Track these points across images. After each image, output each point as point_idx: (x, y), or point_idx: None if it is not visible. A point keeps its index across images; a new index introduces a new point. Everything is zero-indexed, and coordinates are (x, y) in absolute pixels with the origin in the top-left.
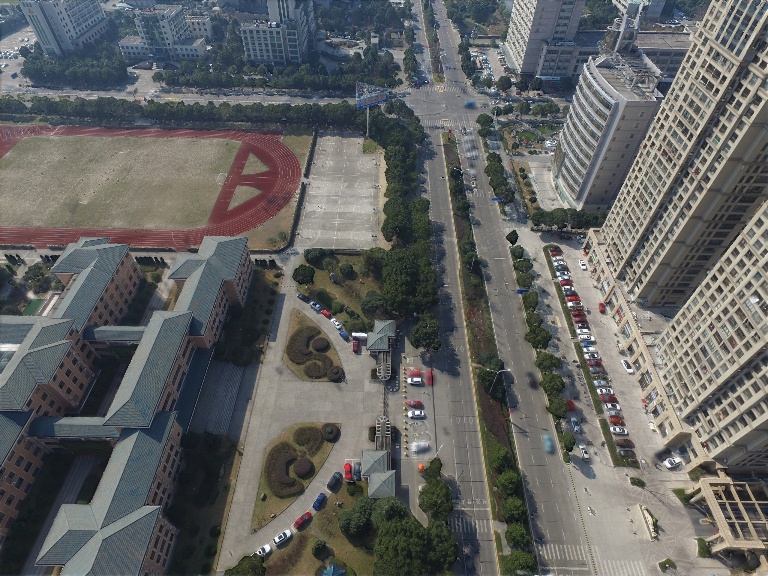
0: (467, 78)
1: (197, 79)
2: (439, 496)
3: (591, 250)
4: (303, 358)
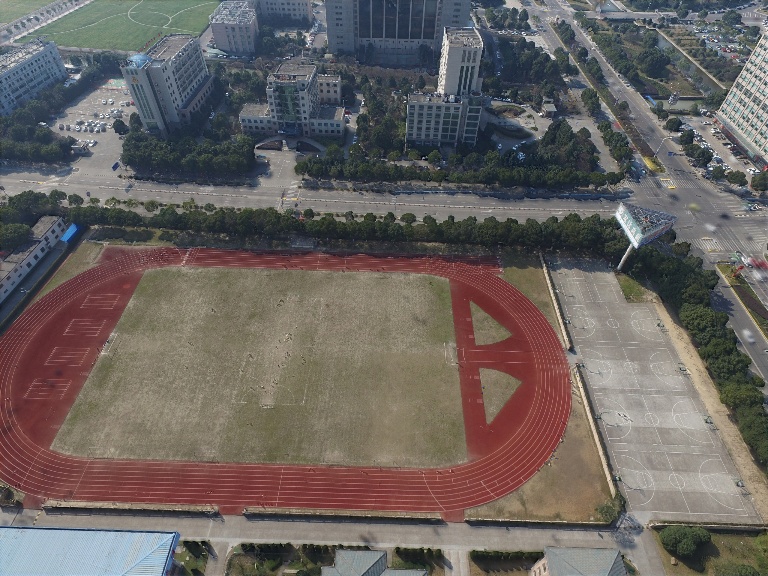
0: (692, 165)
1: (355, 171)
2: None
3: None
4: None
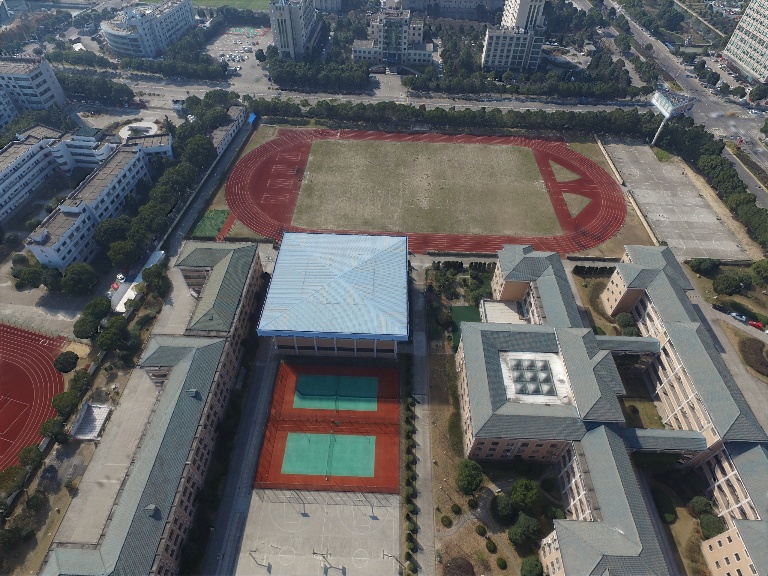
0: (704, 87)
1: (449, 84)
2: None
3: None
4: None
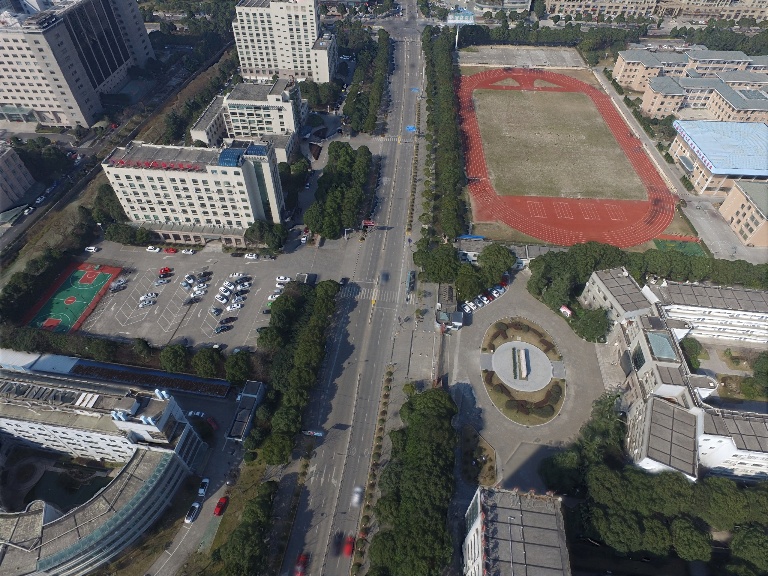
0: None
1: None
2: (703, 33)
3: (558, 7)
4: None
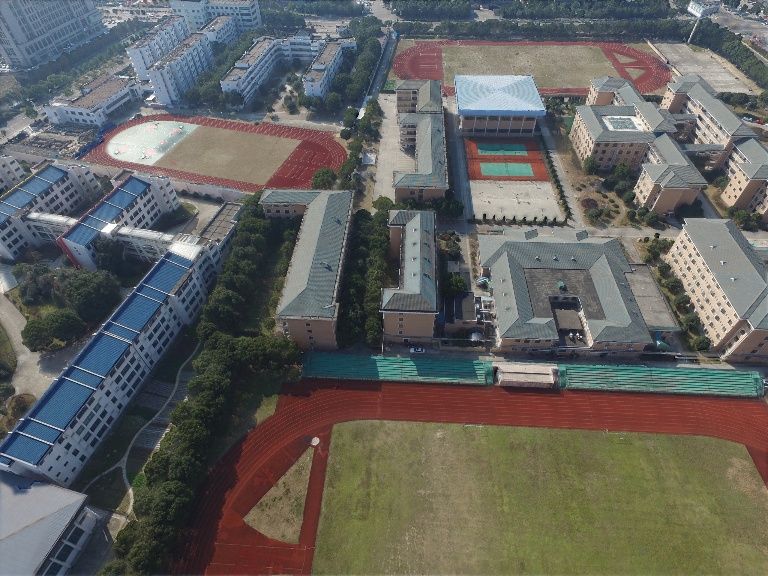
0: (728, 10)
1: (532, 12)
2: None
3: None
4: (766, 139)
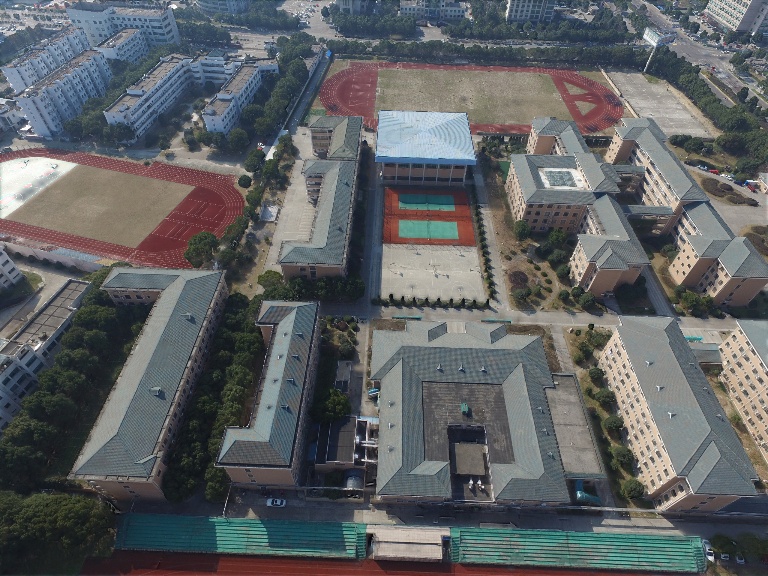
0: (688, 36)
1: (481, 32)
2: None
3: None
4: (721, 194)
